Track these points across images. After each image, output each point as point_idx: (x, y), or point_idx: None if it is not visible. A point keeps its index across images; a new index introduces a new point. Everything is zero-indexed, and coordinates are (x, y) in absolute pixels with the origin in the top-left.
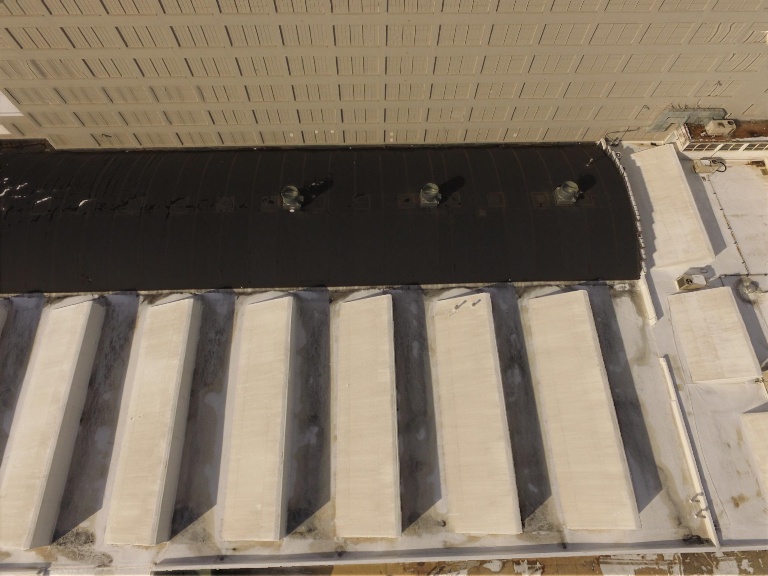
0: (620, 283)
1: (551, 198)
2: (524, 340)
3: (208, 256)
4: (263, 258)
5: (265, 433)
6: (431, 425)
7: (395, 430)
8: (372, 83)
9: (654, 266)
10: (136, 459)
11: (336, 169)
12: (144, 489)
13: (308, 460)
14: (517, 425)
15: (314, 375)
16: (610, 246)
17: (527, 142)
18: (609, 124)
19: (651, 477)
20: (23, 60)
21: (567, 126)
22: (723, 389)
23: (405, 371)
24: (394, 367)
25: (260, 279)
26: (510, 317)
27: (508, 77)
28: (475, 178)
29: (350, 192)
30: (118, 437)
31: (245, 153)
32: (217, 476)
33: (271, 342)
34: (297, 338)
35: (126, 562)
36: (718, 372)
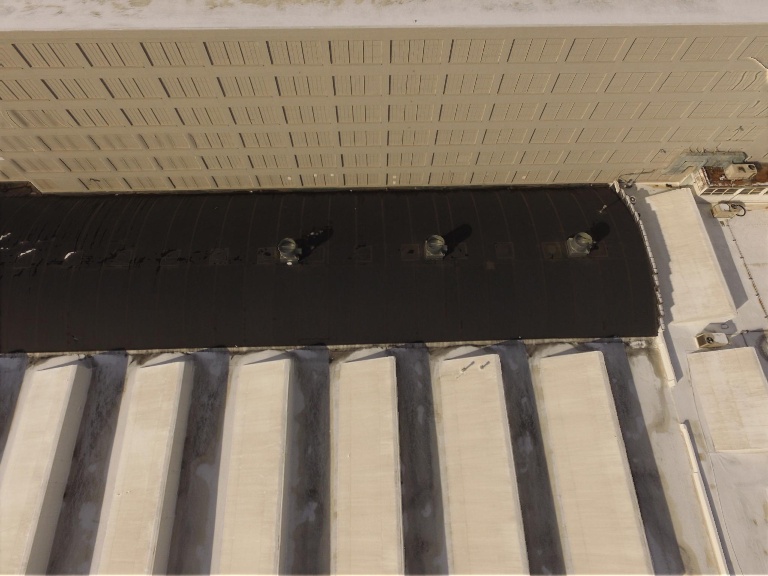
0: (636, 340)
1: (563, 249)
2: (535, 404)
3: (201, 313)
4: (259, 315)
5: (260, 513)
6: (437, 500)
7: (399, 510)
8: (374, 130)
9: (672, 321)
10: (122, 541)
11: (336, 216)
12: None
13: (306, 540)
14: (529, 500)
15: (313, 444)
16: (626, 301)
17: (536, 184)
18: (623, 167)
19: (673, 559)
20: (3, 110)
21: (579, 169)
22: (748, 459)
23: (409, 439)
24: (398, 439)
25: (256, 337)
26: (520, 378)
27: (518, 123)
28: (482, 226)
29: (351, 242)
30: (104, 515)
31: (240, 197)
32: (209, 559)
33: (267, 409)
34: (295, 402)
35: None
36: (743, 441)
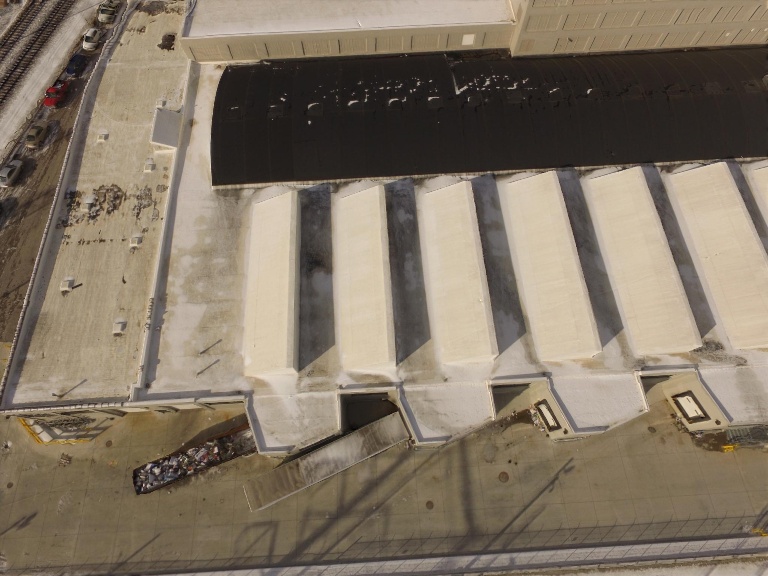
0: None
1: None
2: None
3: (712, 131)
4: (760, 131)
5: None
6: None
7: None
8: None
9: None
10: (734, 285)
11: None
12: (762, 303)
13: None
14: None
15: None
16: None
17: None
18: None
19: None
20: None
21: None
22: None
23: None
24: None
25: (758, 149)
26: None
27: None
28: None
29: None
30: (700, 272)
31: (684, 53)
32: None
33: None
34: None
35: (759, 362)
36: None
